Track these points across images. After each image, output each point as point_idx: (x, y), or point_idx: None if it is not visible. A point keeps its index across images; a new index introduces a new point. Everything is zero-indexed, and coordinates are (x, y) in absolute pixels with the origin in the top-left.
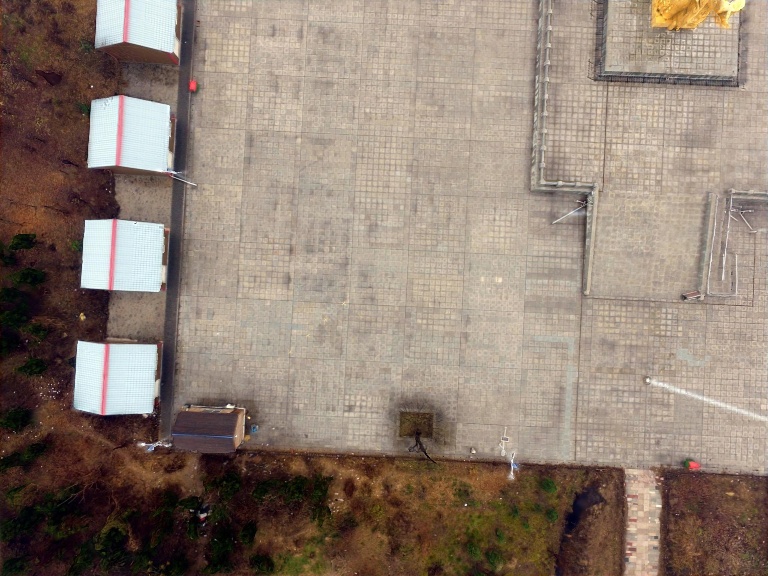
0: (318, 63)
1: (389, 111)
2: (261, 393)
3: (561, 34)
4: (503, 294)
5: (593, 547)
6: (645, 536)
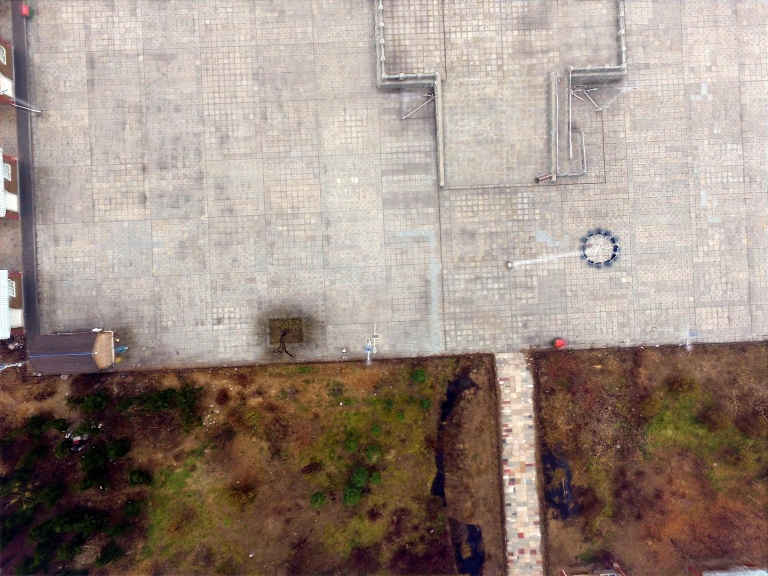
0: None
1: (229, 21)
2: (128, 315)
3: None
4: (360, 194)
5: (468, 431)
6: (519, 416)
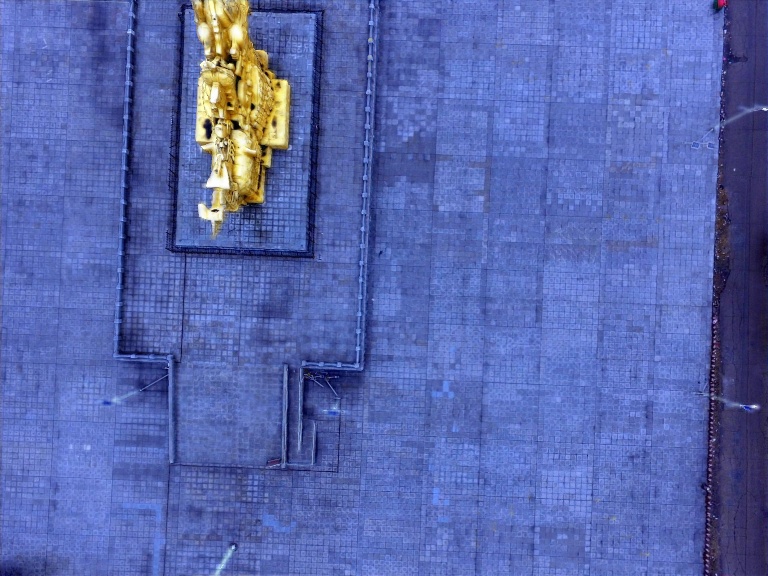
0: None
1: None
2: None
3: (139, 205)
4: (91, 461)
5: None
6: None
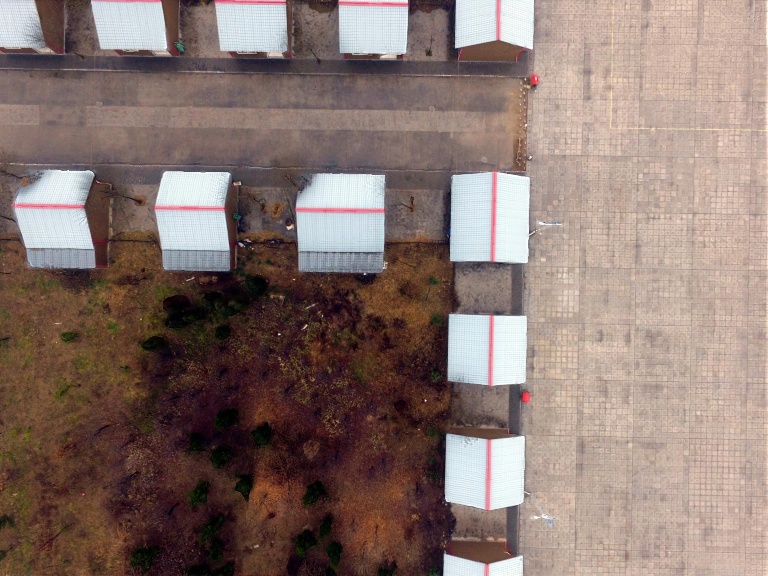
0: (647, 367)
1: (720, 413)
2: None
3: None
4: None
5: None
6: None
